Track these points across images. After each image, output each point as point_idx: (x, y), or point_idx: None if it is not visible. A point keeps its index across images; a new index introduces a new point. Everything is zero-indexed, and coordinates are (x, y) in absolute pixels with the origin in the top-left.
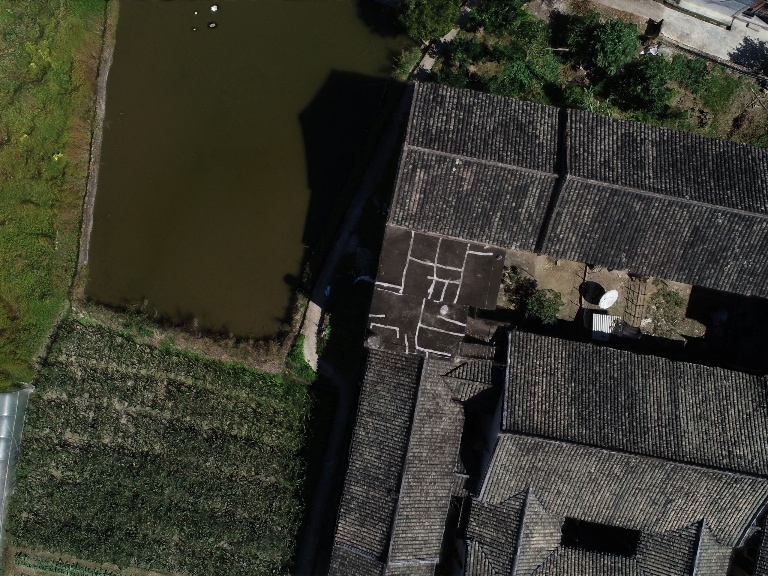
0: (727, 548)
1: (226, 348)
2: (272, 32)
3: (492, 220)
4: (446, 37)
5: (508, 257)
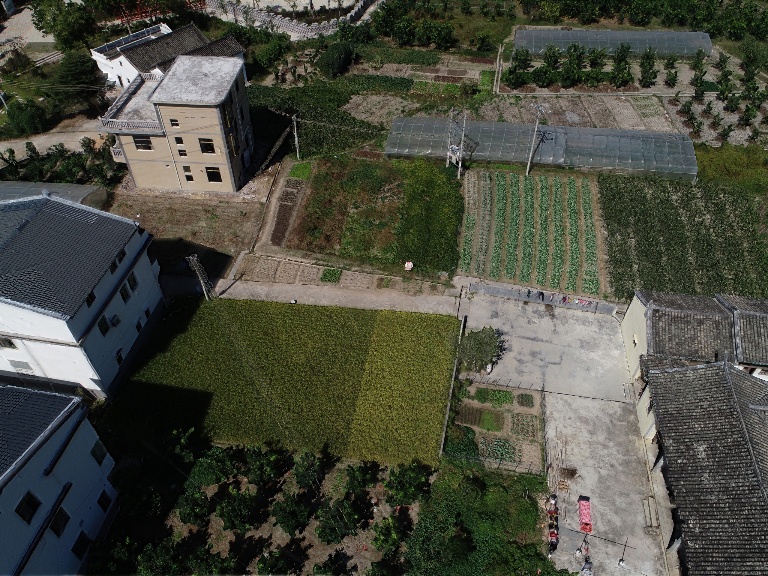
0: None
1: None
2: None
3: None
4: None
5: None
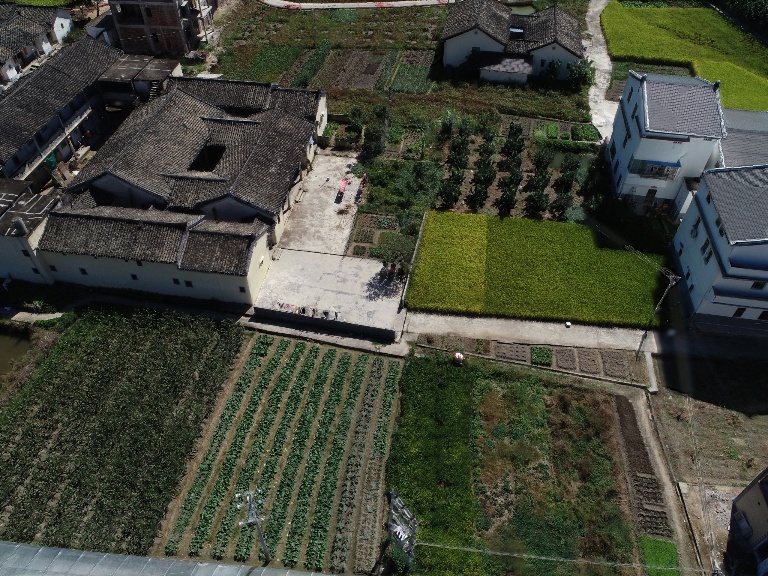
0: None
1: (19, 364)
2: None
3: None
4: None
5: None
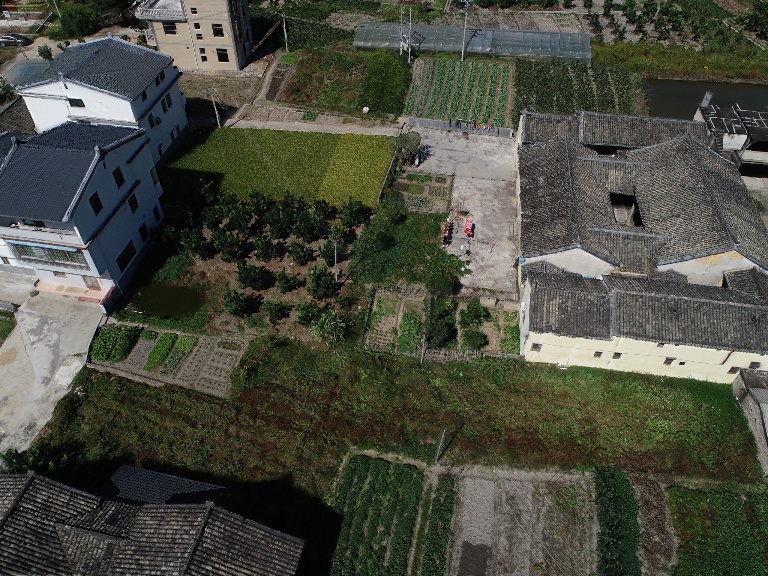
0: (648, 268)
1: None
2: None
3: None
4: None
5: (766, 205)
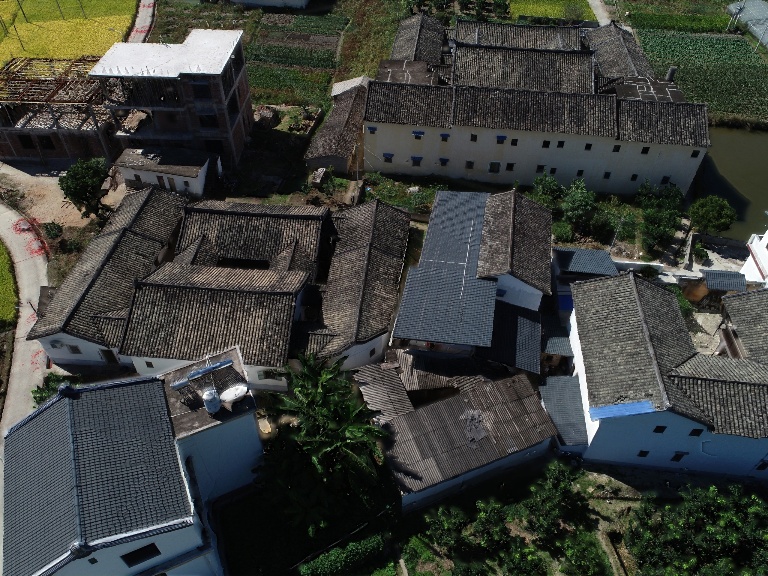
0: None
1: None
2: None
3: None
4: (681, 233)
5: None
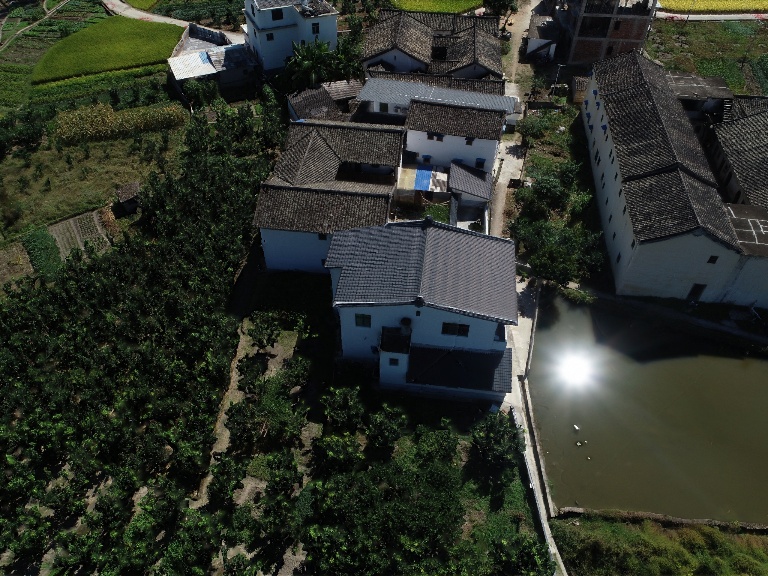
0: None
1: None
2: (569, 399)
3: (712, 203)
4: None
5: None
